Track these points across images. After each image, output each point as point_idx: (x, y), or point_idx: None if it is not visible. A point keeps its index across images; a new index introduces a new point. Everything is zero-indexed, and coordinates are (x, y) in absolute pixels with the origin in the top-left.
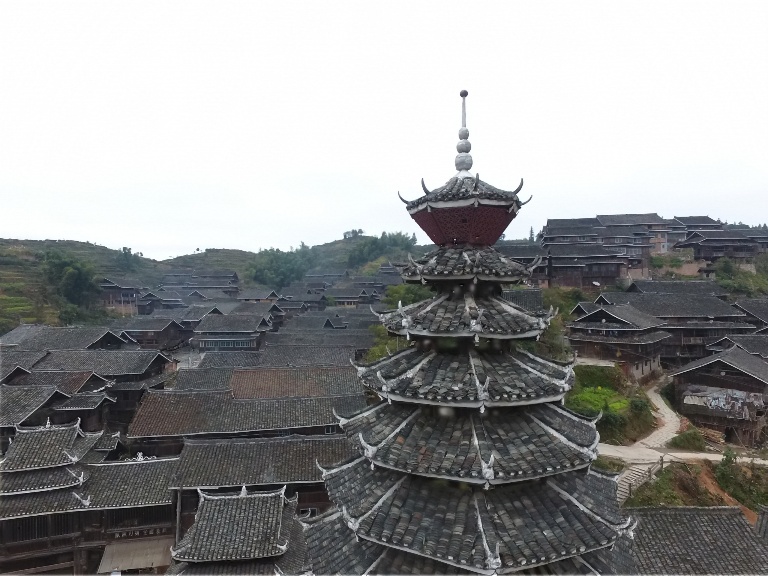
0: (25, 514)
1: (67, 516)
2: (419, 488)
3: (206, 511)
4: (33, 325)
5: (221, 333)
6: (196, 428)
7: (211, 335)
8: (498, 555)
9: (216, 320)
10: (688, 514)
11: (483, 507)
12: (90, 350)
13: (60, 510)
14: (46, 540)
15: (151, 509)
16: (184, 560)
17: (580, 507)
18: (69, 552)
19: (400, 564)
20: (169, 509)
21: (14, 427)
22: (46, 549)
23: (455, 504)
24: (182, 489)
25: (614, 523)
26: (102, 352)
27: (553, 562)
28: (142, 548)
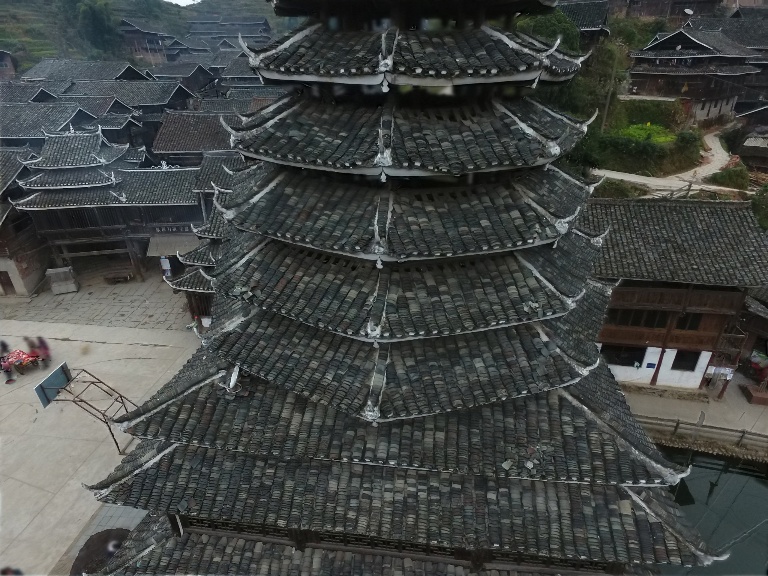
0: (73, 205)
1: (110, 210)
2: (332, 33)
3: (221, 201)
4: (55, 59)
5: (249, 78)
6: (216, 146)
7: (240, 81)
8: (388, 57)
9: (243, 64)
10: (689, 206)
11: (390, 32)
12: (112, 81)
13: (102, 204)
14: (98, 229)
15: (181, 208)
16: (205, 236)
17: (510, 44)
18: (121, 241)
19: (310, 112)
20: (197, 209)
21: (42, 131)
22: (101, 237)
23: (365, 39)
24: (205, 192)
25: (541, 50)
26: (124, 83)
27: (459, 85)
28: (181, 241)
